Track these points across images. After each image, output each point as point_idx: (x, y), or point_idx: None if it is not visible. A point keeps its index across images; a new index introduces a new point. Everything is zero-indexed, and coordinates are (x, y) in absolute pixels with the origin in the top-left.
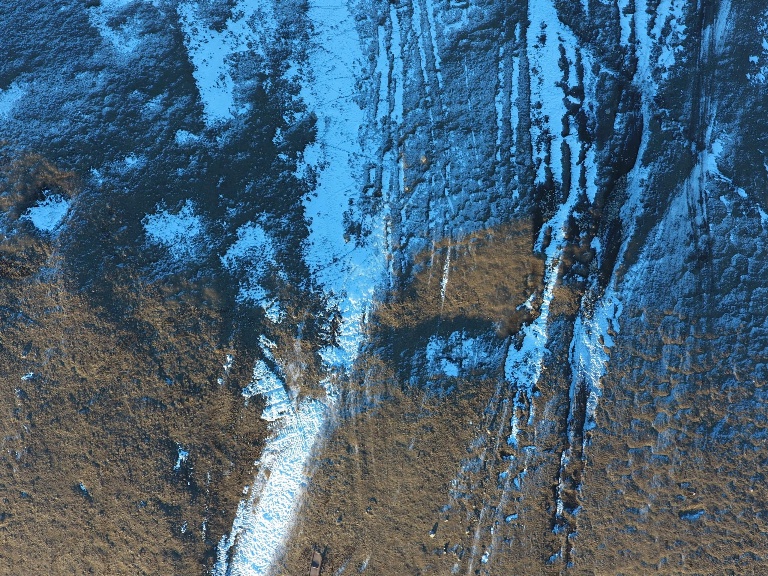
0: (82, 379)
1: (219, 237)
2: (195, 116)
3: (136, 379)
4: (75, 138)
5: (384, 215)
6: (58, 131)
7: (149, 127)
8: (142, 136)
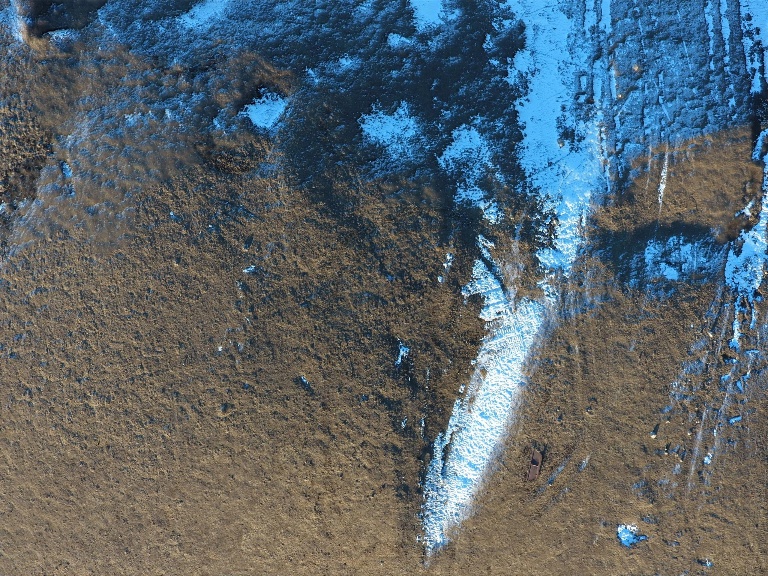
0: (303, 273)
1: (435, 138)
2: (406, 20)
3: (357, 274)
4: (289, 38)
5: (597, 121)
6: (272, 31)
7: (361, 29)
8: (355, 38)
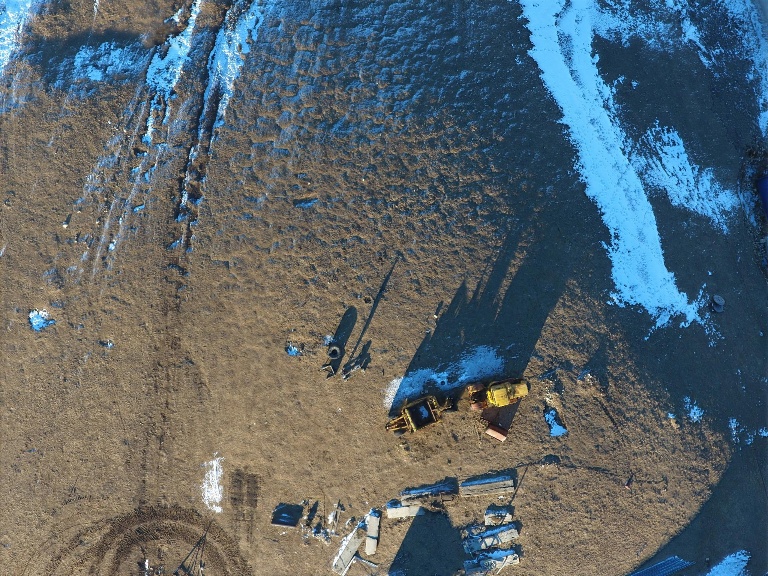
0: None
1: None
2: None
3: None
4: None
5: None
6: None
7: None
8: None
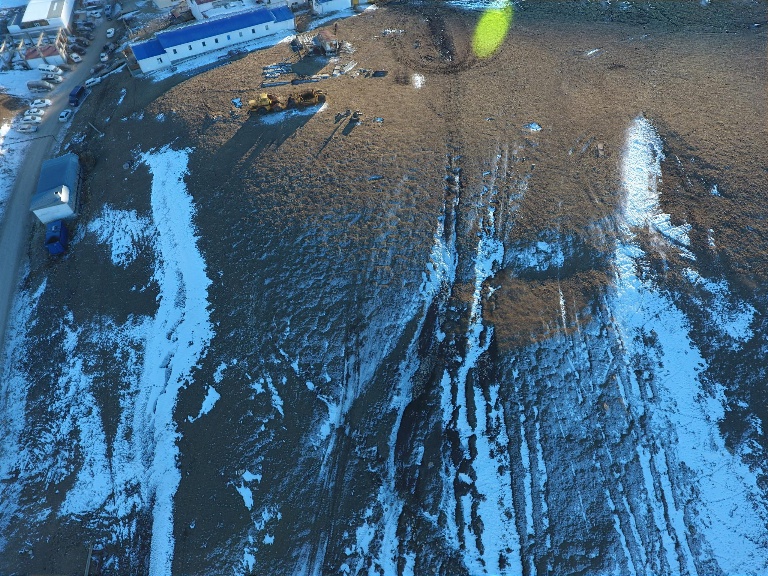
0: None
1: (767, 327)
2: None
3: None
4: None
5: (627, 354)
6: None
7: None
8: None
